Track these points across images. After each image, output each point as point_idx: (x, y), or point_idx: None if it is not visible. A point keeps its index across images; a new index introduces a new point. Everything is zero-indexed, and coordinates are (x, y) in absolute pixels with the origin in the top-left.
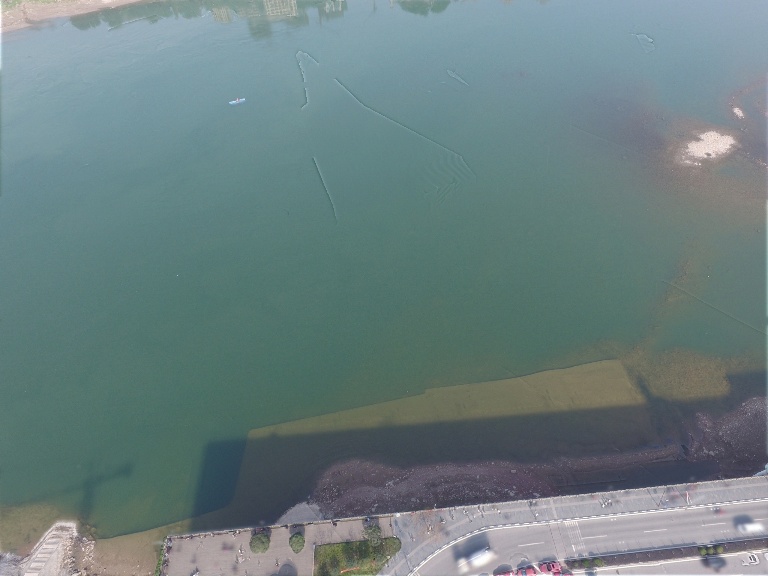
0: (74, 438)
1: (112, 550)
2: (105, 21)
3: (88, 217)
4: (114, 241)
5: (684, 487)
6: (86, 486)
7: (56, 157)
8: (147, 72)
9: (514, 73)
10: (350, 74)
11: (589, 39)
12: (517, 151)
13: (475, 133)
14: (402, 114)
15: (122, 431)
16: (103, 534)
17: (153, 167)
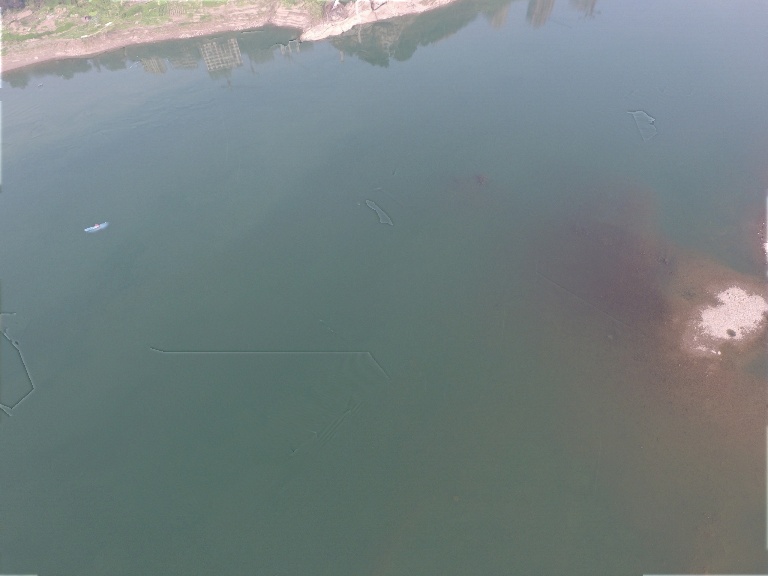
0: None
1: None
2: (6, 80)
3: None
4: None
5: None
6: None
7: None
8: (4, 173)
9: (470, 178)
10: (251, 186)
11: (571, 125)
12: (464, 306)
13: (408, 278)
14: (314, 246)
15: None
16: None
17: None
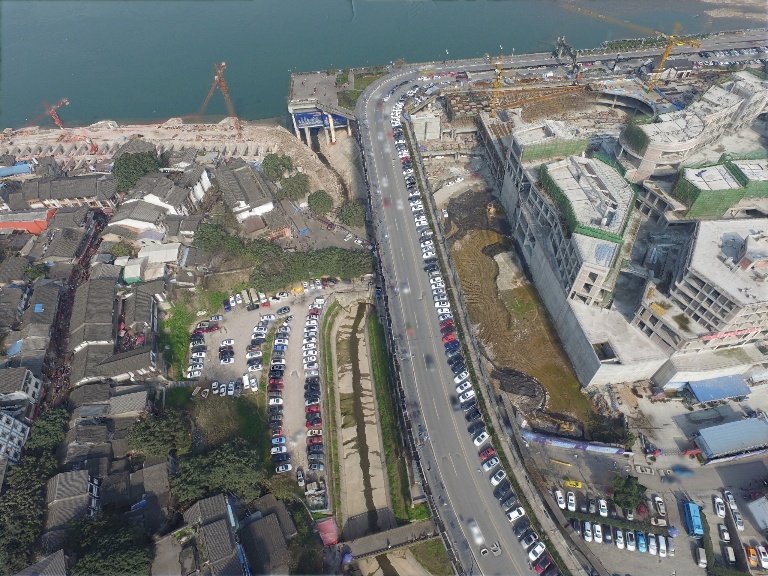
0: None
1: (256, 122)
2: None
3: (203, 32)
4: (222, 40)
5: (511, 57)
6: (237, 109)
7: (173, 10)
8: None
9: None
10: None
11: None
12: (466, 4)
13: None
14: None
15: (250, 94)
16: None
17: (235, 13)
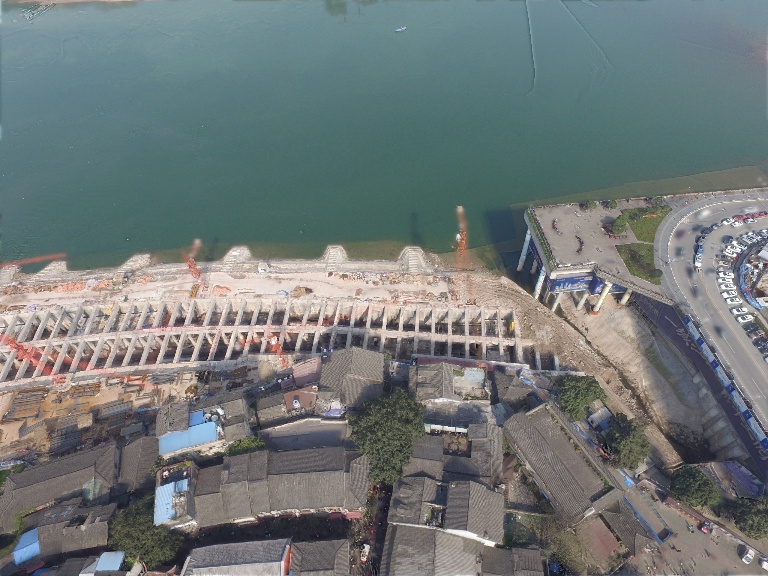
0: (392, 211)
1: (450, 257)
2: None
3: (326, 101)
4: (354, 114)
5: None
6: (415, 231)
7: (278, 67)
8: (313, 14)
9: (618, 7)
10: (488, 8)
11: None
12: (633, 61)
13: None
14: None
15: (424, 206)
16: (439, 252)
17: (356, 72)
